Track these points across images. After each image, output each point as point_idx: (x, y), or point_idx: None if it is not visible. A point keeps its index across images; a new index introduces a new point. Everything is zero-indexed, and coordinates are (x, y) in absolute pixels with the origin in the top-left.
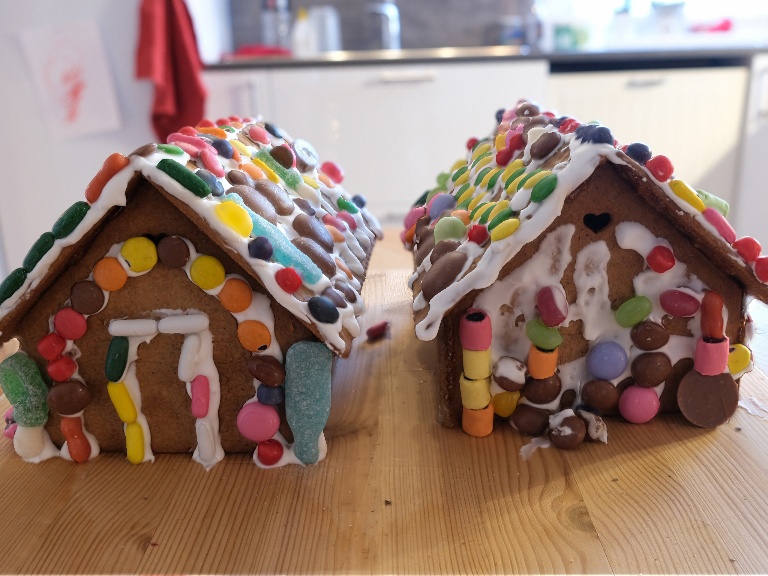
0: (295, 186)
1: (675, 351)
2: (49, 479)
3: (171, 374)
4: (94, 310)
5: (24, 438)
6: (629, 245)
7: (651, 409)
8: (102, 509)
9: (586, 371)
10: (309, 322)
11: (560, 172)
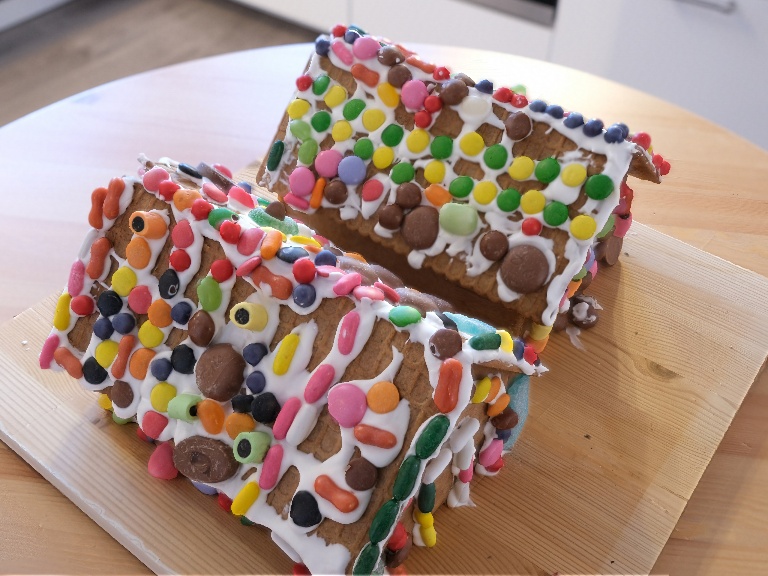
0: None
1: None
2: None
3: None
4: None
5: None
6: None
7: None
8: None
9: None
10: None
11: (610, 174)
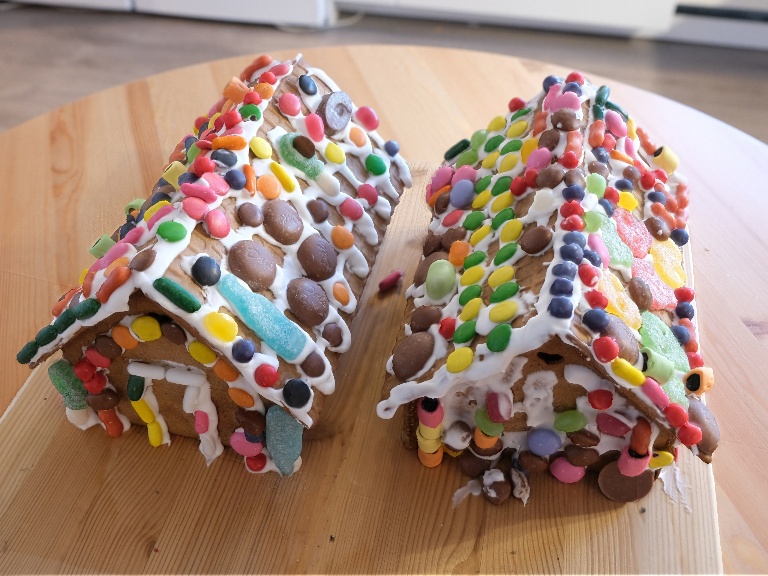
0: (315, 177)
1: (605, 446)
2: (91, 453)
3: (180, 398)
4: (114, 357)
5: (73, 415)
6: (574, 382)
7: (575, 478)
8: (125, 499)
9: (526, 441)
10: (282, 406)
11: (514, 333)
